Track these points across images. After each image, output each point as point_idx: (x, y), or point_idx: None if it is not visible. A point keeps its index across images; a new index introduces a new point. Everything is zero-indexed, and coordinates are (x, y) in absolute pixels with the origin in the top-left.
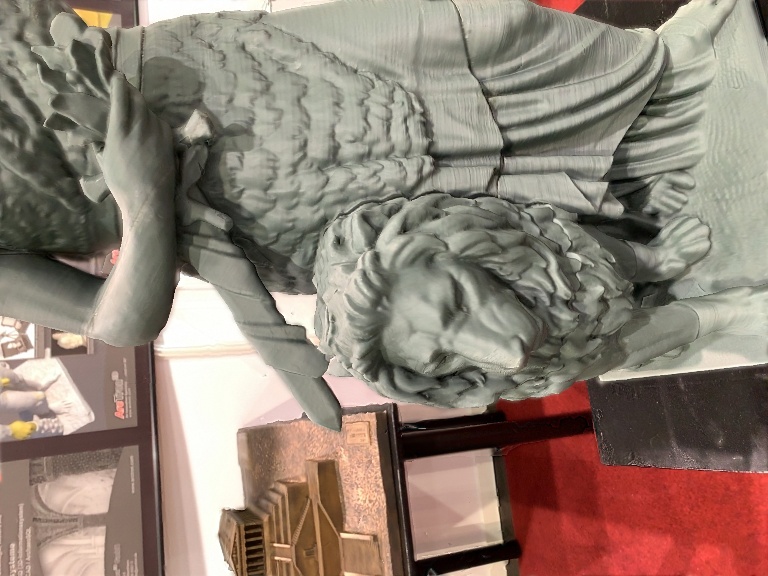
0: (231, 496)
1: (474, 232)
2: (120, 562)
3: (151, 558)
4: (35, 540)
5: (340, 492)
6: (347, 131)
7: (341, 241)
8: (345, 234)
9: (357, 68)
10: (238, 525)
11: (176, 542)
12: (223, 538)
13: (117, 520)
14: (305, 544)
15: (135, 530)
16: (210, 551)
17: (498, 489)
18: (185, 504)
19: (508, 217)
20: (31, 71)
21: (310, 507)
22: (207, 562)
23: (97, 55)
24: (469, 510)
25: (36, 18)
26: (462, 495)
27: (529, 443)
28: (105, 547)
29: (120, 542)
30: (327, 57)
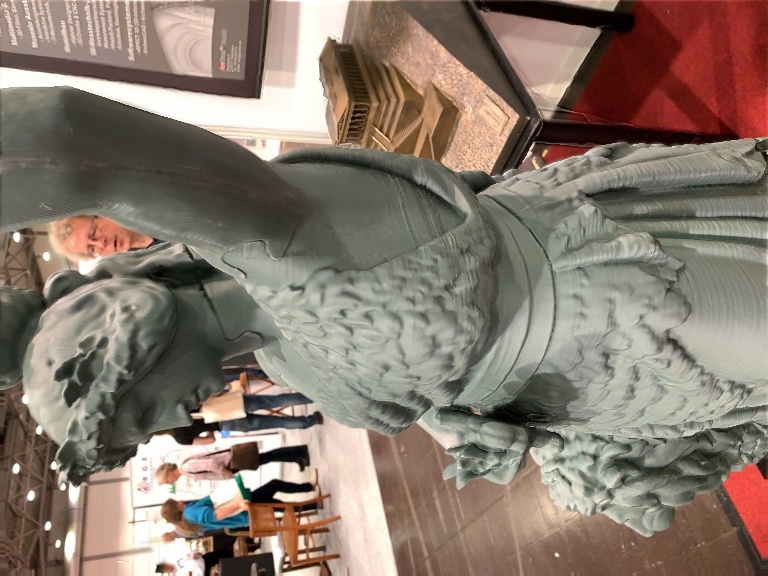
0: (334, 5)
1: (684, 502)
2: (226, 45)
3: (253, 49)
4: (148, 3)
5: (451, 135)
6: (663, 423)
7: (596, 459)
8: (602, 456)
9: (722, 378)
10: (350, 102)
11: (275, 32)
12: (326, 75)
13: (225, 5)
14: (403, 150)
15: (241, 17)
16: (304, 51)
17: (578, 73)
18: (289, 0)
19: (725, 449)
20: (439, 395)
21: (419, 126)
22: (299, 57)
23: (510, 461)
24: (541, 80)
25: (464, 367)
26: (544, 67)
27: (635, 71)
28: (213, 28)
29: (227, 27)
30: (702, 384)
